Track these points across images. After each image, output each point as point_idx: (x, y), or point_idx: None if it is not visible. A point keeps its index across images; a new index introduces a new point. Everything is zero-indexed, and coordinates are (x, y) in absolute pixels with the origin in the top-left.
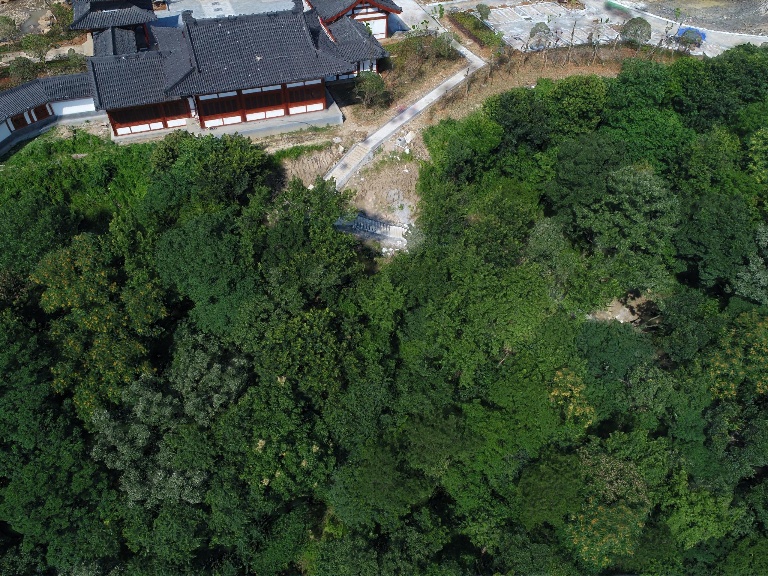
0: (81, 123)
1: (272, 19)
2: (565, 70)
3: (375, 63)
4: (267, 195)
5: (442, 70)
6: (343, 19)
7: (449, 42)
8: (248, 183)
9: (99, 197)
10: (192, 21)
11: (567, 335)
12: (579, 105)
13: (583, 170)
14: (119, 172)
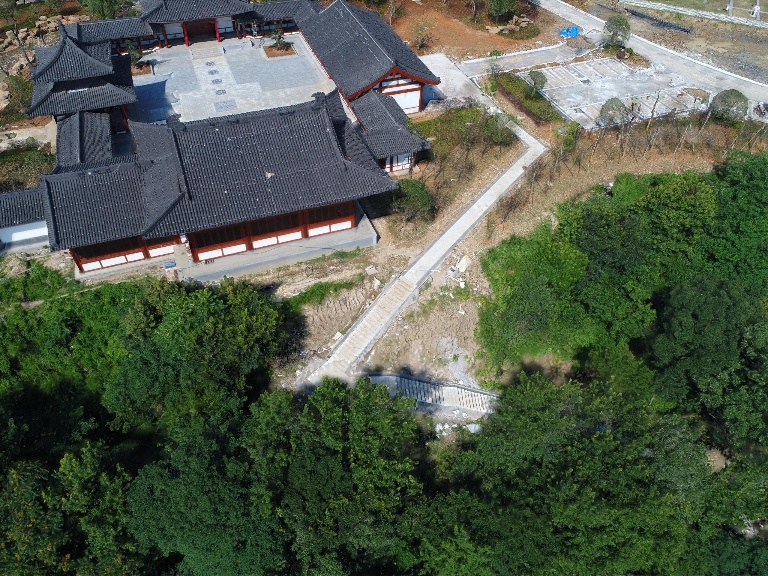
0: (37, 249)
1: (286, 118)
2: (647, 159)
3: (412, 155)
4: (288, 407)
5: (494, 160)
6: (369, 94)
7: (503, 126)
8: (258, 358)
9: (58, 361)
10: (180, 127)
11: (700, 571)
12: (681, 220)
13: (710, 332)
14: (85, 324)
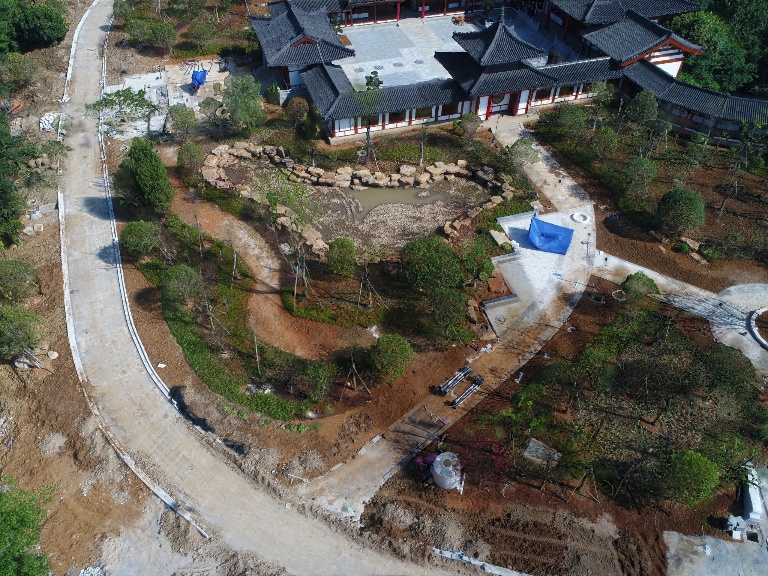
0: None
1: None
2: None
3: None
4: None
5: None
6: None
7: None
8: None
9: None
10: None
11: None
12: None
13: None
14: None
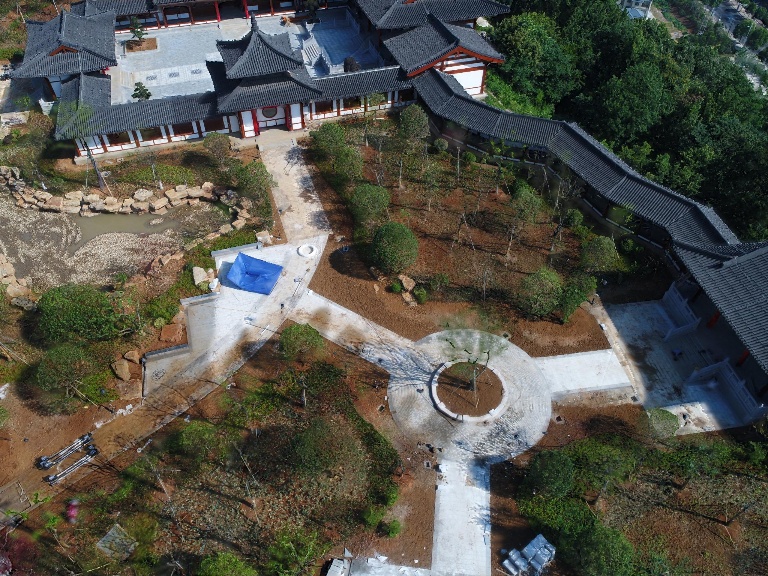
0: None
1: None
2: None
3: None
4: None
5: None
6: None
7: None
8: None
9: None
10: None
11: None
12: None
13: None
14: None
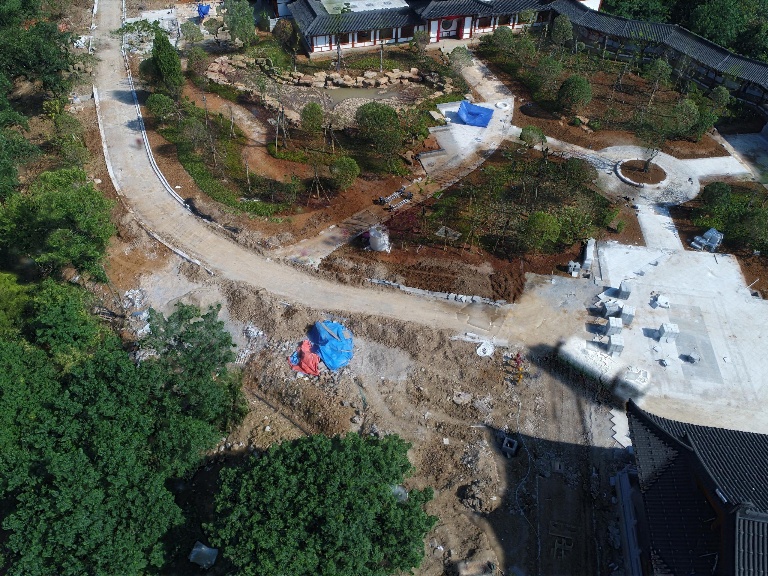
0: None
1: None
2: None
3: None
4: None
5: None
6: None
7: None
8: None
9: None
10: None
11: None
12: None
13: None
14: None
